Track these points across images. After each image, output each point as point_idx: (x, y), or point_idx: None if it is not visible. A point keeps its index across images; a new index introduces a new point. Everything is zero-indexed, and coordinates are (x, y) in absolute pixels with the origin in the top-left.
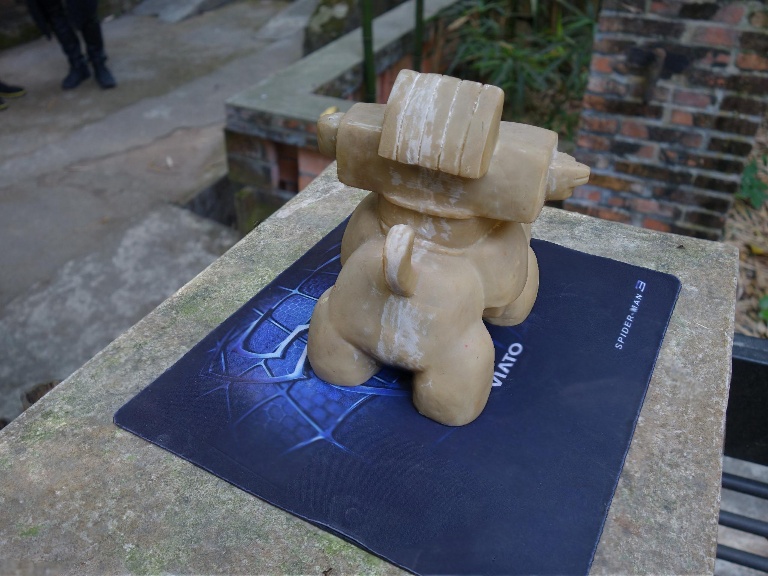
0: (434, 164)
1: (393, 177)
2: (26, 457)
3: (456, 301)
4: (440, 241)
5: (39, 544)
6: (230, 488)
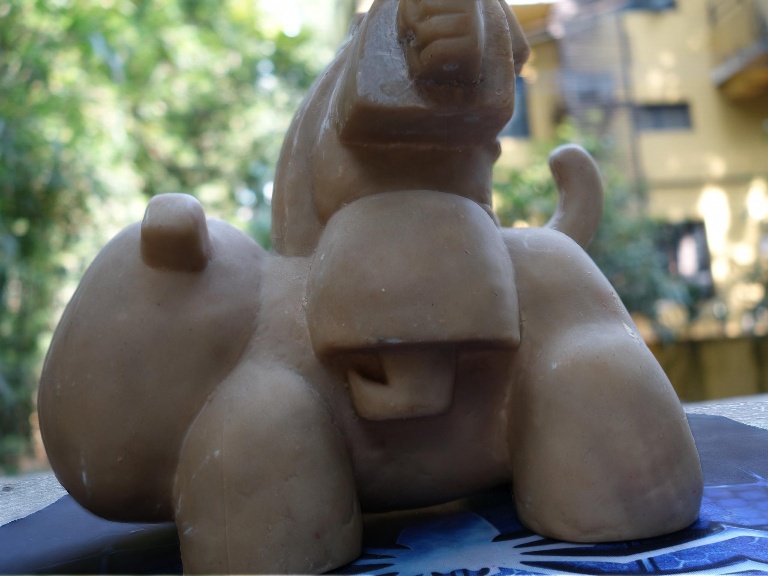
0: None
1: None
2: None
3: None
4: None
5: None
6: None
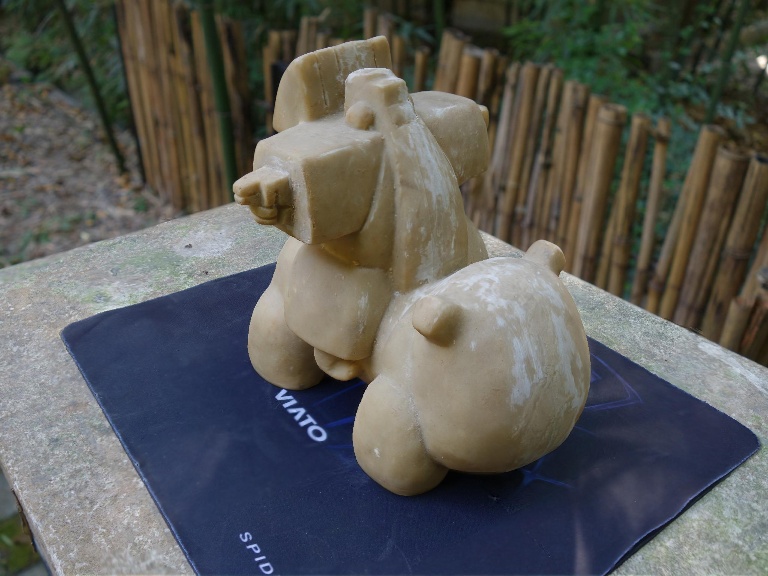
0: None
1: None
2: None
3: None
4: None
5: None
6: None
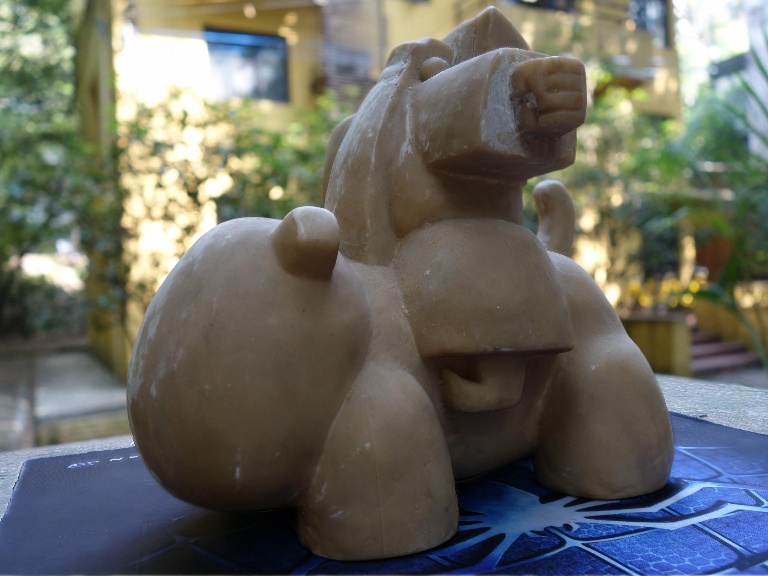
0: None
1: None
2: None
3: None
4: None
5: None
6: None
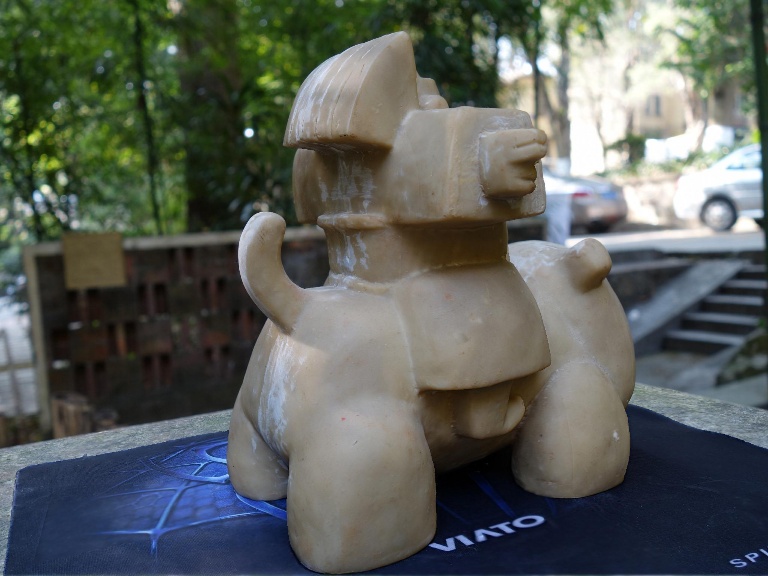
0: (313, 131)
1: (322, 191)
2: None
3: (338, 341)
4: (361, 273)
5: None
6: (3, 547)
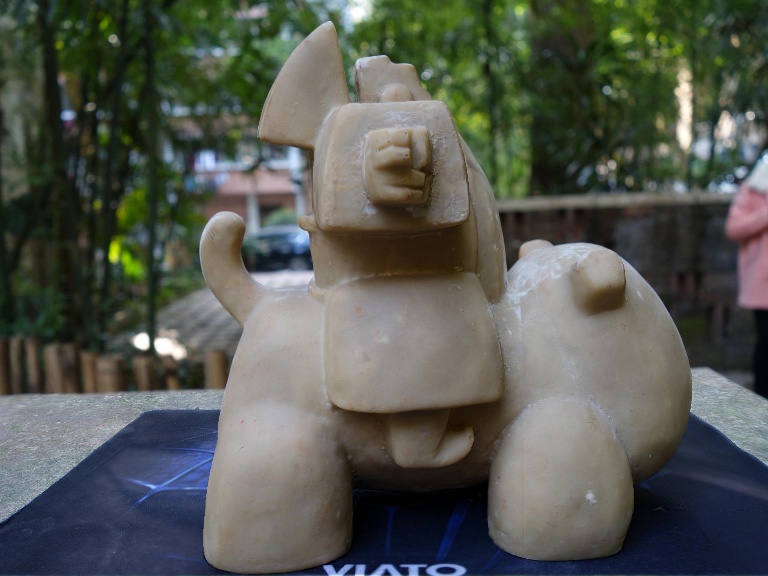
0: None
1: None
2: (99, 405)
3: (256, 344)
4: None
5: (0, 432)
6: None
